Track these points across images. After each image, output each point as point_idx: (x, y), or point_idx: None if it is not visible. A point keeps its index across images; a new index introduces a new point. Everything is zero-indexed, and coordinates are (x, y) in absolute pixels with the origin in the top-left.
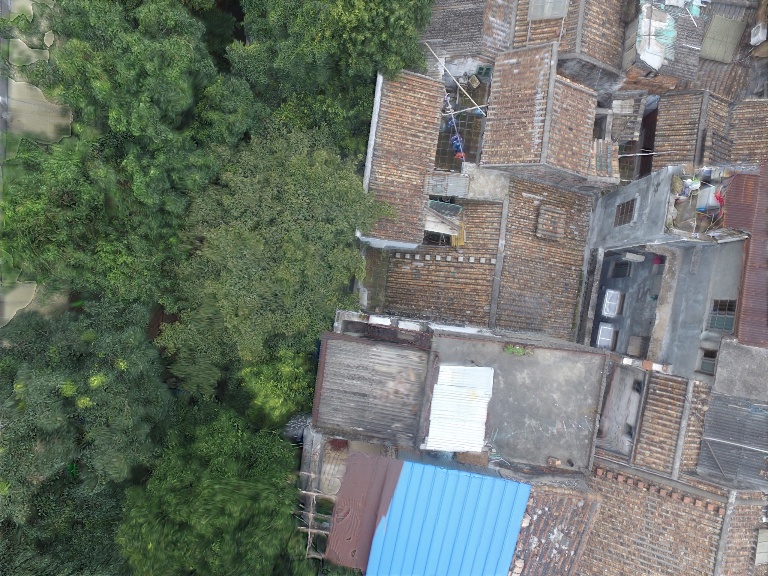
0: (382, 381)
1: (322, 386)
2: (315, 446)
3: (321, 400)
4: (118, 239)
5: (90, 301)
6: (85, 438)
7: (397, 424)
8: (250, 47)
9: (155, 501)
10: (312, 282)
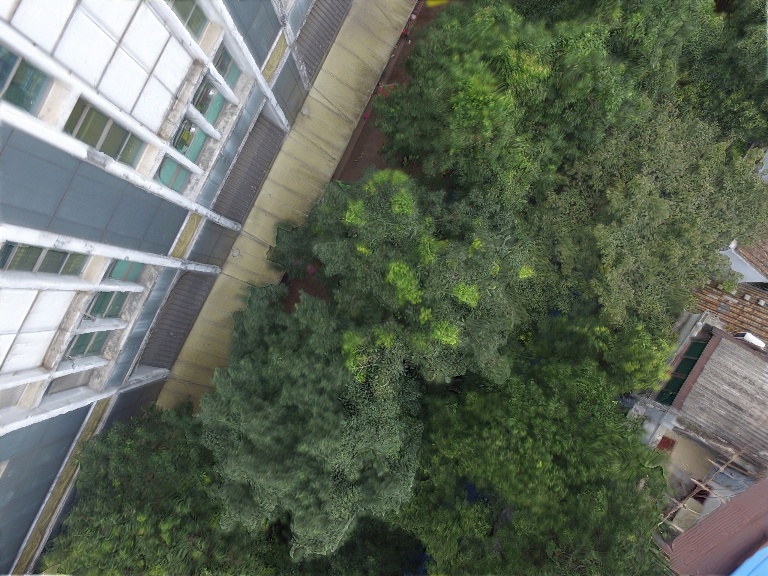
0: (766, 403)
1: (697, 380)
2: (657, 435)
3: (690, 393)
4: (529, 143)
5: (479, 191)
6: None
7: (767, 453)
8: (719, 17)
9: (524, 419)
10: (677, 271)
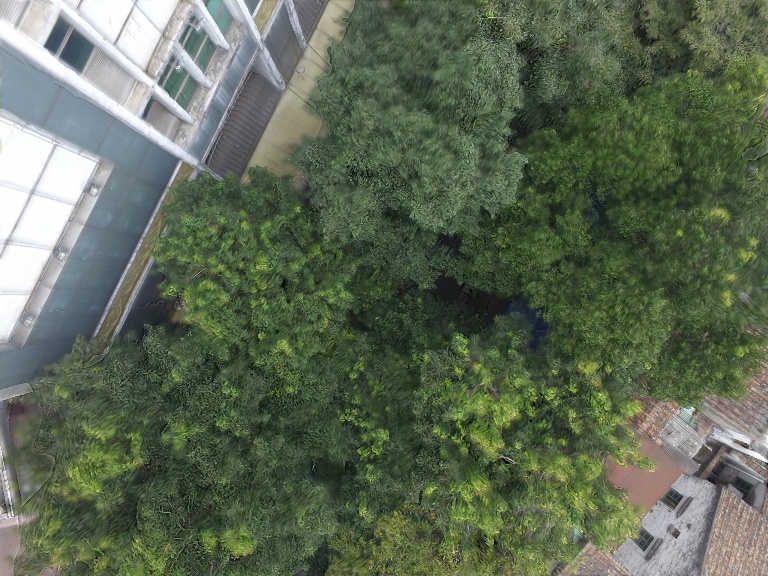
0: None
1: None
2: None
3: None
4: None
5: None
6: (537, 50)
7: None
8: None
9: None
10: (763, 35)
